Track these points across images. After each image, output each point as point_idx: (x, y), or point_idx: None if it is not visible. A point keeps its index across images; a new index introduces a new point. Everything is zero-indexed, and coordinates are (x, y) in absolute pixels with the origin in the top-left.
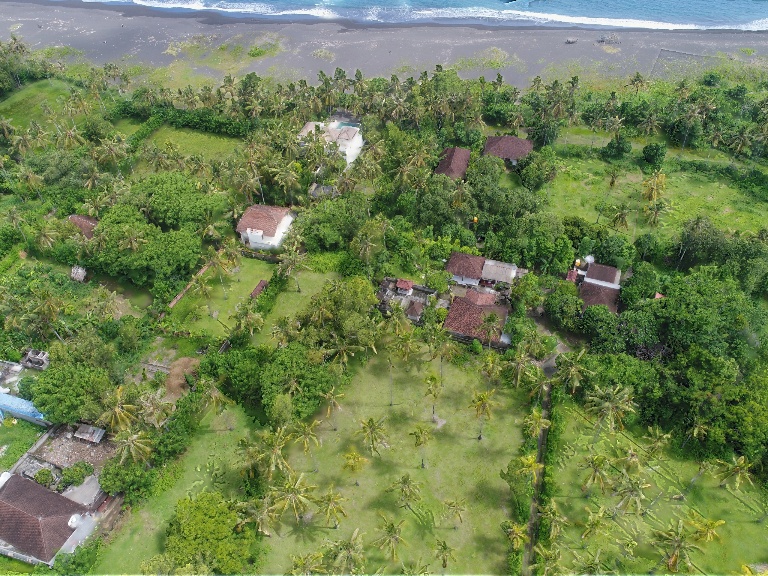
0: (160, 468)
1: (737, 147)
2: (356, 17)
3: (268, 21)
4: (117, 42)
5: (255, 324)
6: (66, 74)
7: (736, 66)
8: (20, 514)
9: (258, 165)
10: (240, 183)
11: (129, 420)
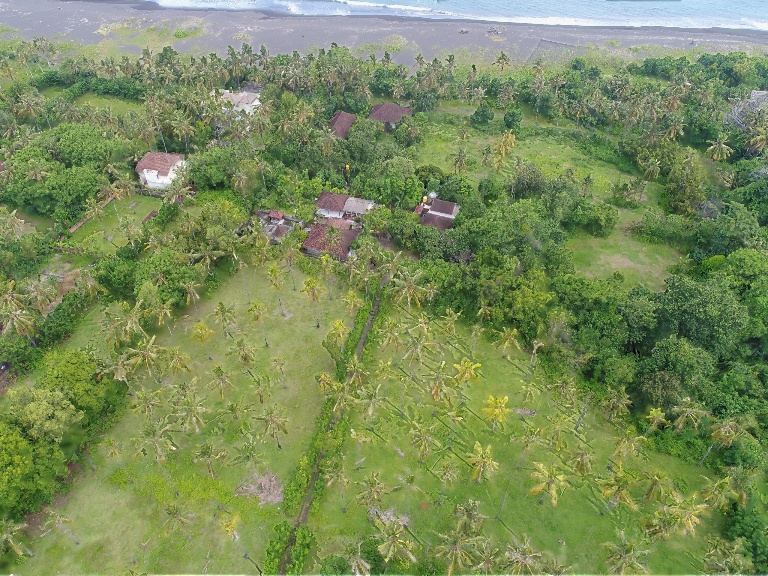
0: (45, 349)
1: (577, 114)
2: (278, 7)
3: (197, 8)
4: (52, 22)
5: (136, 236)
6: (0, 48)
7: (601, 54)
8: None
9: (161, 120)
10: (140, 131)
11: (18, 307)
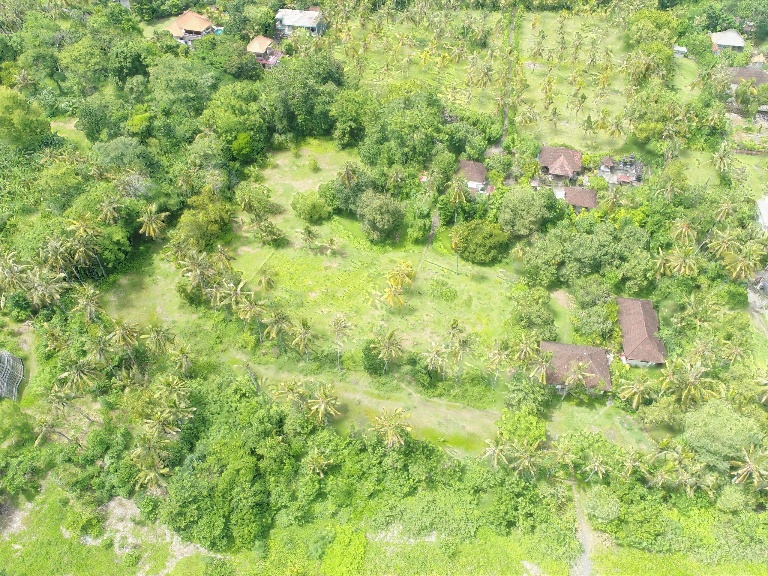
0: None
1: None
2: None
3: None
4: None
5: None
6: None
7: None
8: None
9: None
10: None
11: None
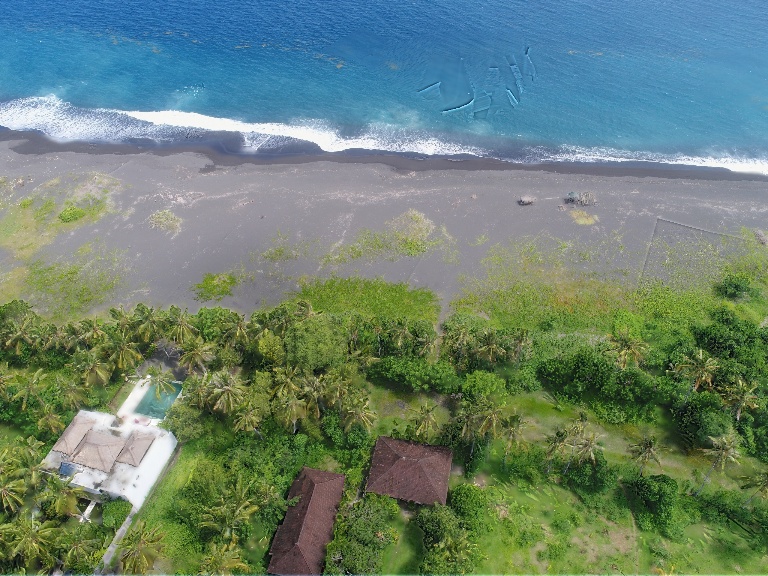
0: None
1: None
2: (231, 142)
3: (108, 148)
4: None
5: None
6: None
7: None
8: None
9: None
10: None
11: None
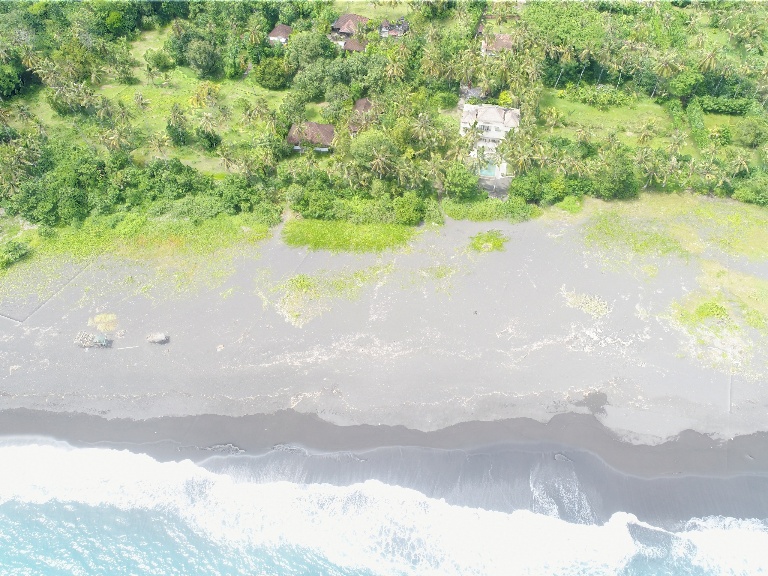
0: None
1: None
2: (598, 468)
3: None
4: None
5: None
6: None
7: None
8: None
9: None
10: None
11: None
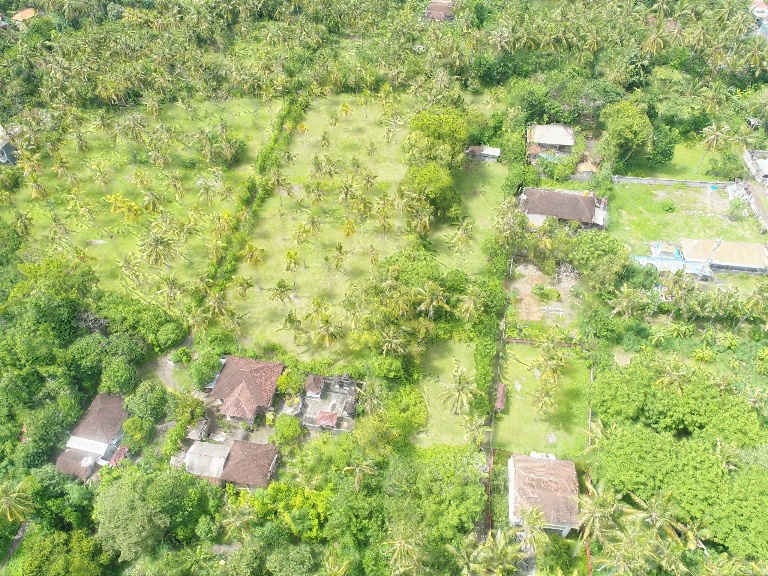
0: None
1: None
2: None
3: None
4: None
5: None
6: None
7: None
8: (559, 192)
9: None
10: None
11: None
